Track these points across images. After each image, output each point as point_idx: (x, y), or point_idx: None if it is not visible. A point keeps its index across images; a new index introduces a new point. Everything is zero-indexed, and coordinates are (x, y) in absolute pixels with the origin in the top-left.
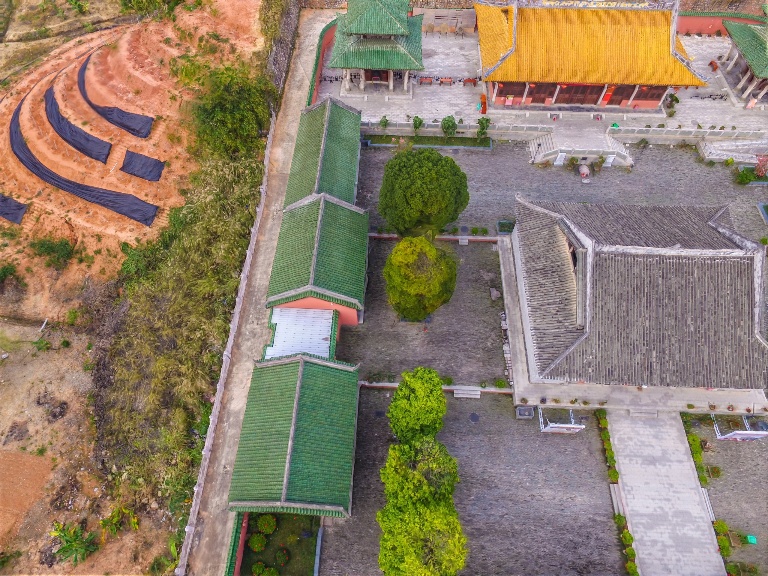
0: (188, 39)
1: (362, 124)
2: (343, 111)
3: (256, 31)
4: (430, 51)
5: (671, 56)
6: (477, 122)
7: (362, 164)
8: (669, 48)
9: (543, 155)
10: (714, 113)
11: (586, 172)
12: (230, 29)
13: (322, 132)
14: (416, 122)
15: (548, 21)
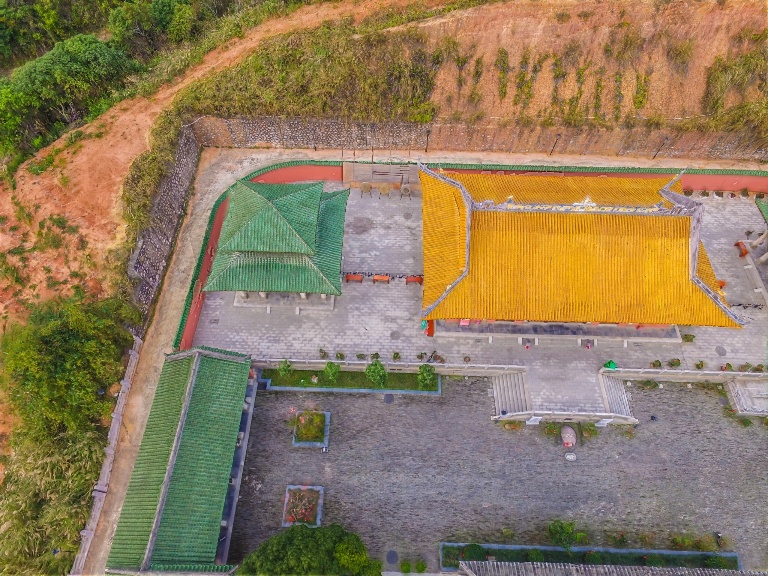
0: (27, 221)
1: (257, 361)
2: (220, 364)
3: (117, 216)
4: (365, 221)
5: (691, 282)
6: (420, 352)
7: (255, 424)
8: (688, 270)
9: (510, 415)
10: (746, 333)
11: (571, 443)
12: (84, 208)
13: (176, 425)
14: (328, 373)
15: (516, 229)
